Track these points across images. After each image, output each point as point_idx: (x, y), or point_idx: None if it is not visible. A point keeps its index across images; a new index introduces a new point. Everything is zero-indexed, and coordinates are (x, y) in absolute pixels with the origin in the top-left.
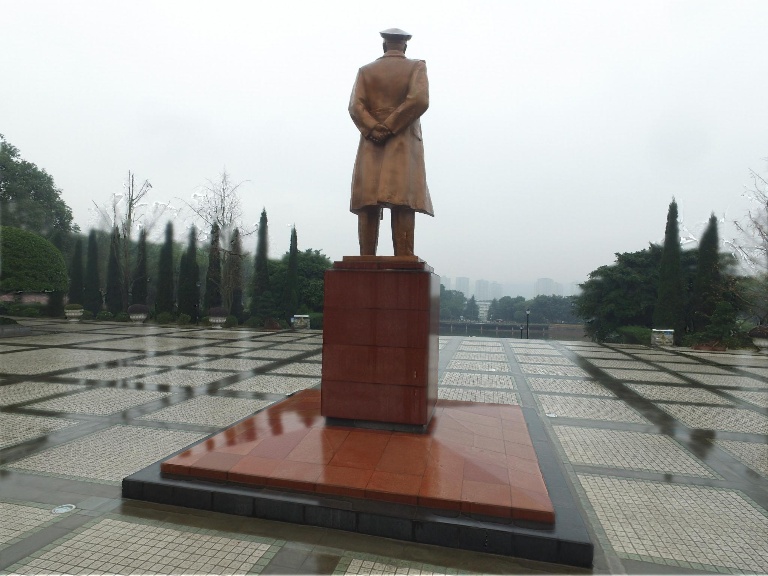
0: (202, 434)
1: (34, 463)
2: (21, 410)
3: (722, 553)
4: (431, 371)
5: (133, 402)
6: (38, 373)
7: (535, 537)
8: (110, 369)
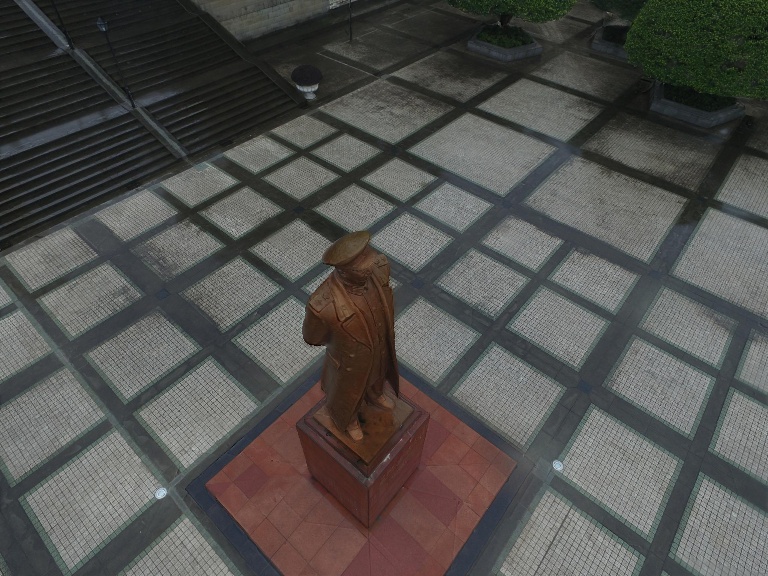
0: (440, 376)
1: (420, 307)
2: (533, 287)
3: (145, 573)
4: (322, 475)
5: (544, 341)
6: (679, 277)
7: (206, 469)
8: (707, 322)
